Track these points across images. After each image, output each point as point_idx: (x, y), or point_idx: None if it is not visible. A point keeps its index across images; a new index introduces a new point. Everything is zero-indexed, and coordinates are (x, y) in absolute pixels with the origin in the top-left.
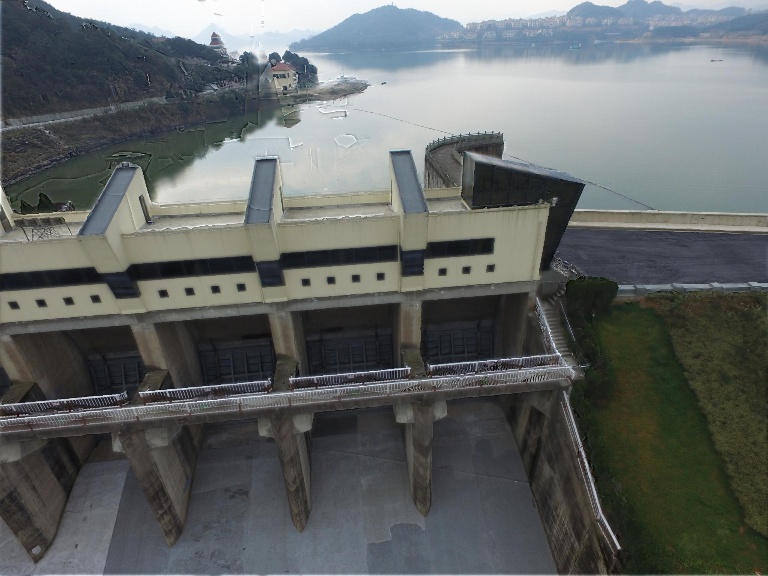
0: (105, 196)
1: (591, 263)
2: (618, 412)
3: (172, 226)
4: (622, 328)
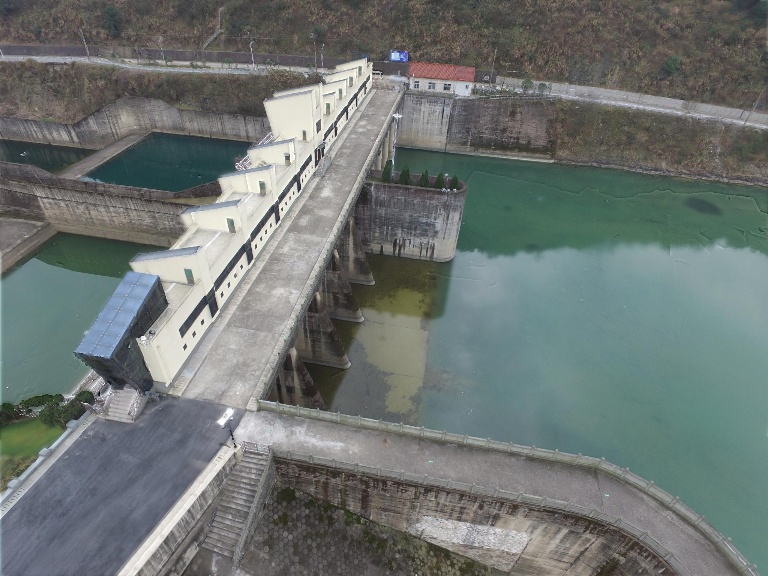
0: (250, 170)
1: (111, 454)
2: (39, 431)
3: (249, 201)
4: (50, 438)
